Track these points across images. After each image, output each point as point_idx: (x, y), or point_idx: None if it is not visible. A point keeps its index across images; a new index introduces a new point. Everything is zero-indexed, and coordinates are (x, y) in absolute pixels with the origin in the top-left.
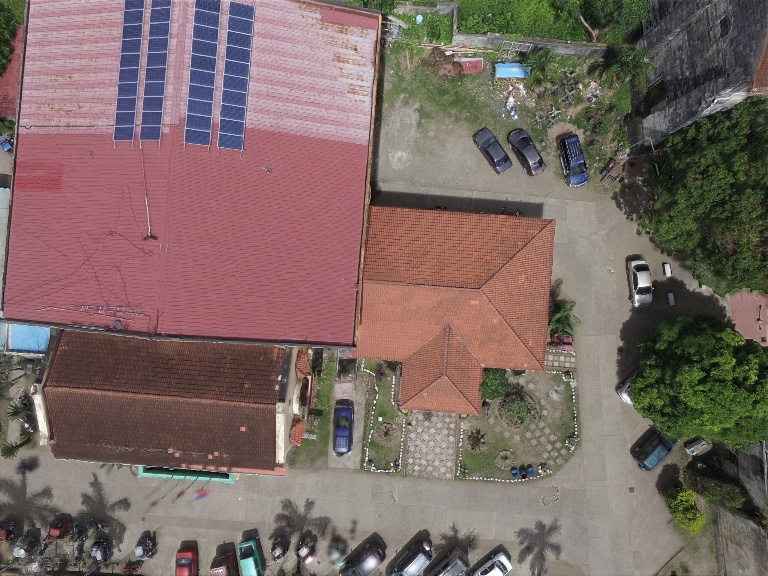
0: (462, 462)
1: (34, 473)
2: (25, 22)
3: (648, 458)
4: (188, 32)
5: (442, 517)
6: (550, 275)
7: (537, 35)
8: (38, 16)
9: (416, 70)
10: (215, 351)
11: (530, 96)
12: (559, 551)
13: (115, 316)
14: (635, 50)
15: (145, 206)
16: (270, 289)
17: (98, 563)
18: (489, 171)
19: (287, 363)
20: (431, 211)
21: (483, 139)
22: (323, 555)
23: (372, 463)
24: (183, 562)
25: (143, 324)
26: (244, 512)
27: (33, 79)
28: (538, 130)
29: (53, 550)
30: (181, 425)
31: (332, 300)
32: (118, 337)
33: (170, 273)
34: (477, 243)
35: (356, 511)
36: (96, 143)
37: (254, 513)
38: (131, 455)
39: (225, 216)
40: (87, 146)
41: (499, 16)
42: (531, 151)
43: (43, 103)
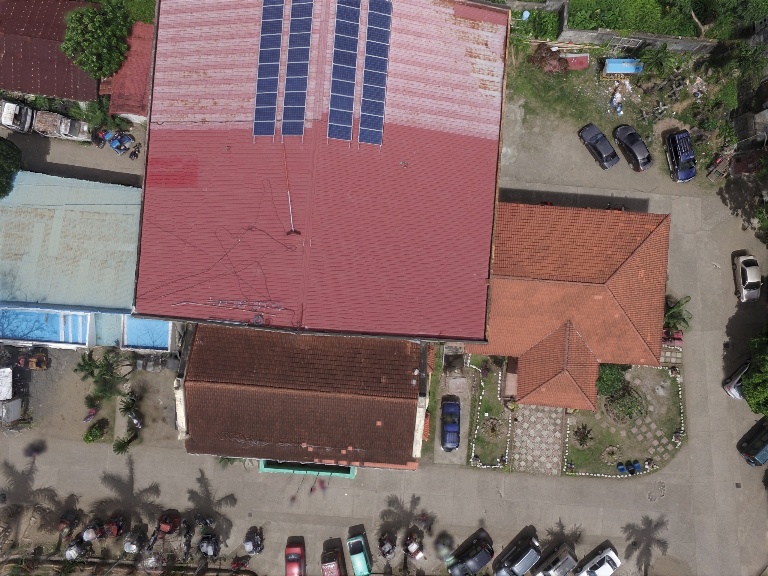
0: (568, 458)
1: (141, 469)
2: (156, 18)
3: (759, 453)
4: (330, 27)
5: (548, 513)
6: (666, 270)
7: (645, 31)
8: (170, 12)
9: (521, 66)
10: (349, 346)
11: (636, 92)
12: (666, 547)
13: (256, 311)
14: (755, 45)
15: (287, 201)
16: (406, 284)
17: (206, 558)
18: (594, 167)
19: (424, 357)
20: (547, 206)
21: (590, 135)
22: (429, 551)
23: (478, 459)
24: (293, 557)
25: (286, 318)
26: (350, 508)
27: (165, 75)
28: (644, 126)
29: (160, 545)
30: (318, 419)
31: (464, 295)
32: (252, 332)
33: (313, 268)
34: (596, 238)
35: (462, 507)
36: (233, 138)
37: (360, 509)
38: (264, 450)
39: (364, 211)
40: (224, 141)
41: (608, 12)
42: (639, 147)
43: (176, 99)
